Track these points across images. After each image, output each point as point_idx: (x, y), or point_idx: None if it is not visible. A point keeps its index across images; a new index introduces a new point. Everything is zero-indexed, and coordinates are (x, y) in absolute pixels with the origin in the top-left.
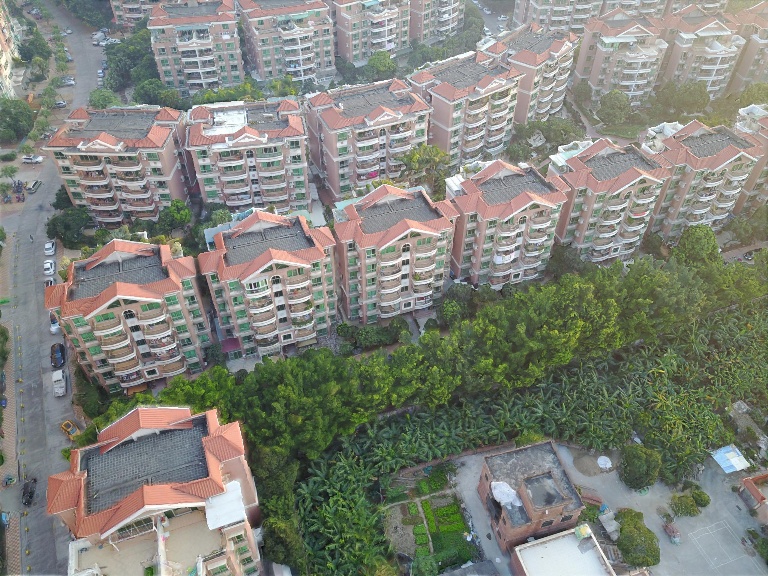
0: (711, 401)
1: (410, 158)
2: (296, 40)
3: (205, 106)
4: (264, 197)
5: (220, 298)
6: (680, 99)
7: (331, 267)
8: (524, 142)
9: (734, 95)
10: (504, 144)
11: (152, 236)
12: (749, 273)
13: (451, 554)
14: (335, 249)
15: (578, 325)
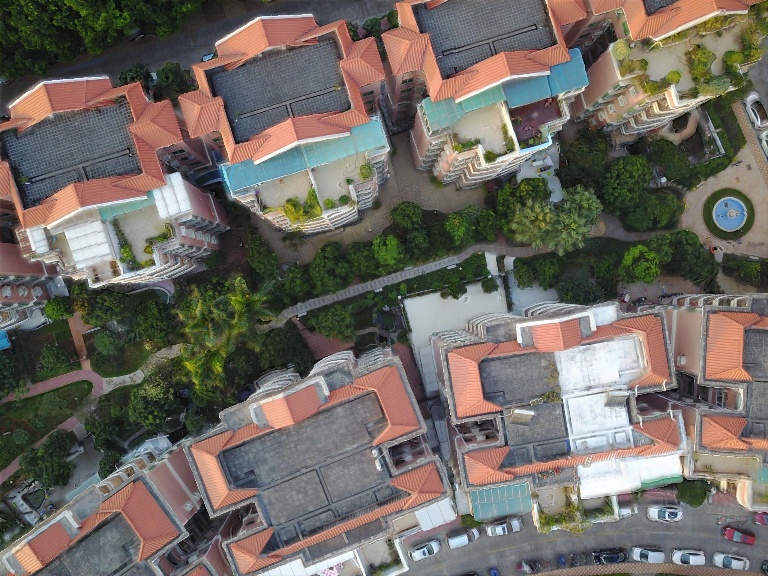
0: None
1: (249, 303)
2: None
3: (657, 448)
4: None
5: None
6: None
7: None
8: None
9: None
10: None
11: None
12: None
13: None
14: None
15: None
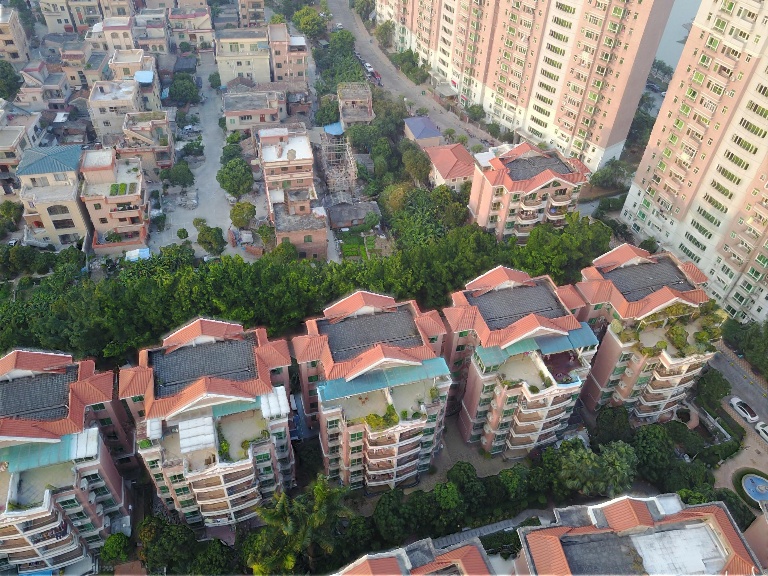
0: None
1: (329, 495)
2: None
3: None
4: None
5: None
6: None
7: None
8: None
9: None
10: None
11: None
12: None
13: (355, 226)
14: None
15: None
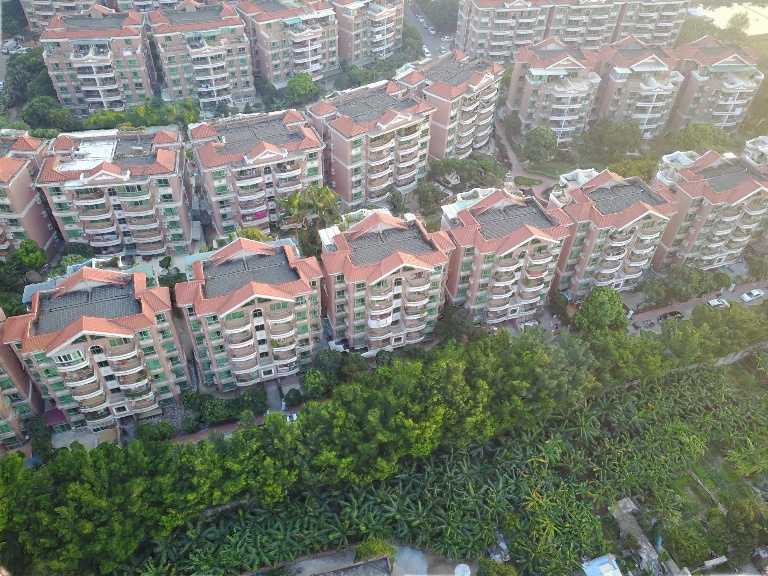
0: (593, 499)
1: (290, 202)
2: (207, 59)
3: (69, 135)
4: (134, 238)
5: (34, 368)
6: (611, 138)
7: (171, 332)
8: (442, 179)
9: (672, 134)
10: (418, 181)
11: None
12: (652, 346)
13: None
14: (173, 313)
15: (438, 413)
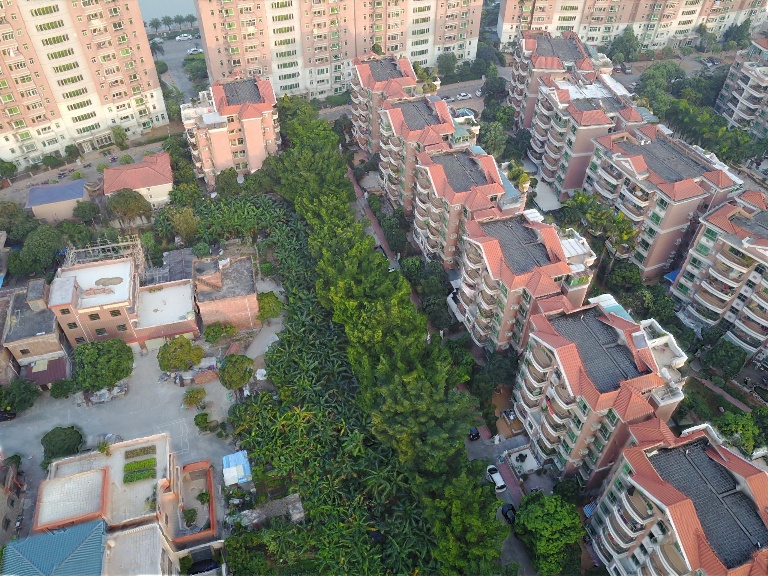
0: None
1: None
2: None
3: None
4: None
5: None
6: None
7: None
8: None
9: None
10: None
11: (486, 116)
12: None
13: None
14: None
15: None
